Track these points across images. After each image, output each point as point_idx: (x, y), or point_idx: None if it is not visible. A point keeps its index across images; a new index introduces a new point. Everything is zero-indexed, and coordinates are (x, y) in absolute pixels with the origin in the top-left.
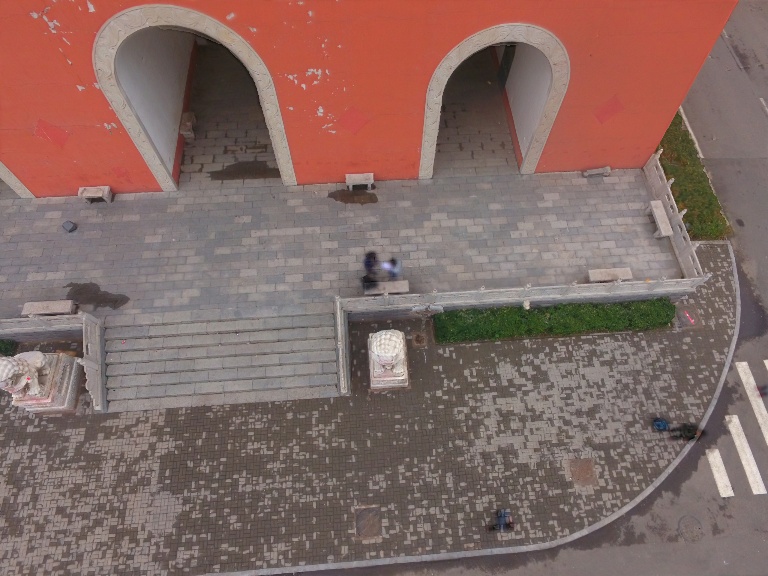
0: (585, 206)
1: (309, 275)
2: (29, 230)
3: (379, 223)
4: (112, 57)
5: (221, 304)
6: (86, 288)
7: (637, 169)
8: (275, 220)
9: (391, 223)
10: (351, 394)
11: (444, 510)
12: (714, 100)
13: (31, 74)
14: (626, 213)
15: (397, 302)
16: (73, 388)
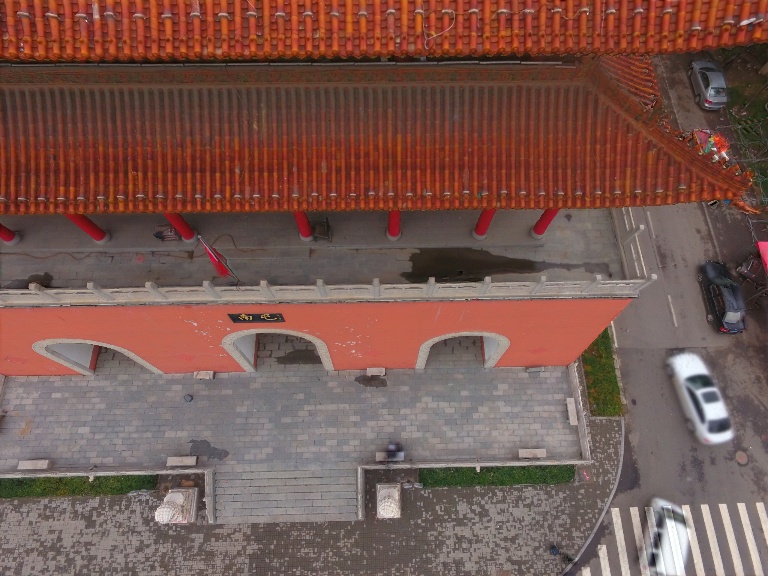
0: (524, 395)
1: (341, 441)
2: (163, 399)
3: (387, 403)
4: (234, 340)
5: (286, 460)
6: (202, 444)
7: (564, 367)
8: (320, 398)
9: (395, 403)
10: (365, 519)
11: None
12: None
13: (185, 343)
14: (551, 402)
15: None
16: (196, 508)
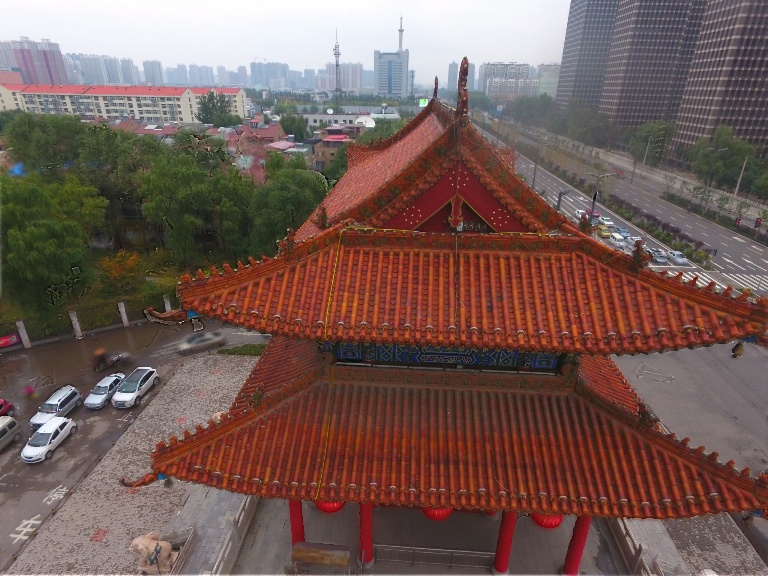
0: None
1: None
2: None
3: None
4: None
5: None
6: None
7: None
8: None
9: None
10: None
11: None
12: None
13: None
14: None
15: None
16: None
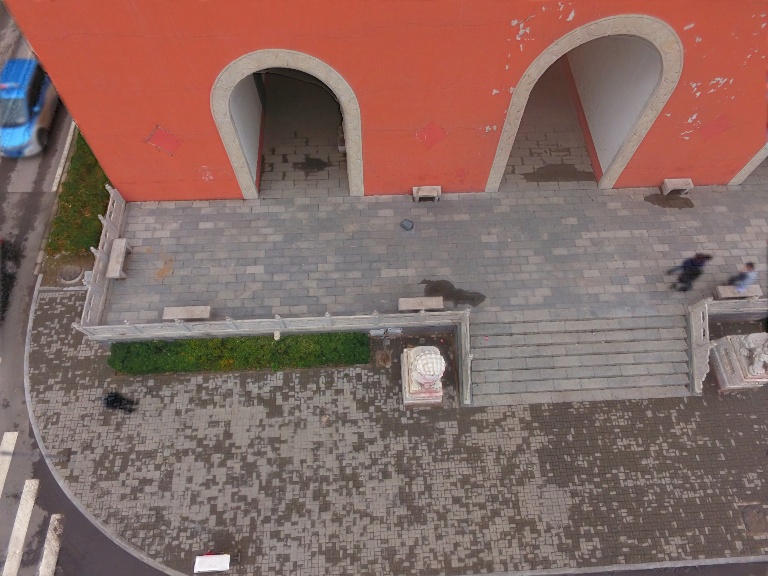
0: None
1: (651, 277)
2: (368, 227)
3: (702, 228)
4: (549, 63)
5: (575, 304)
6: (440, 285)
7: None
8: (601, 222)
9: (714, 228)
10: (702, 394)
11: None
12: None
13: (461, 78)
14: None
15: (750, 305)
16: None
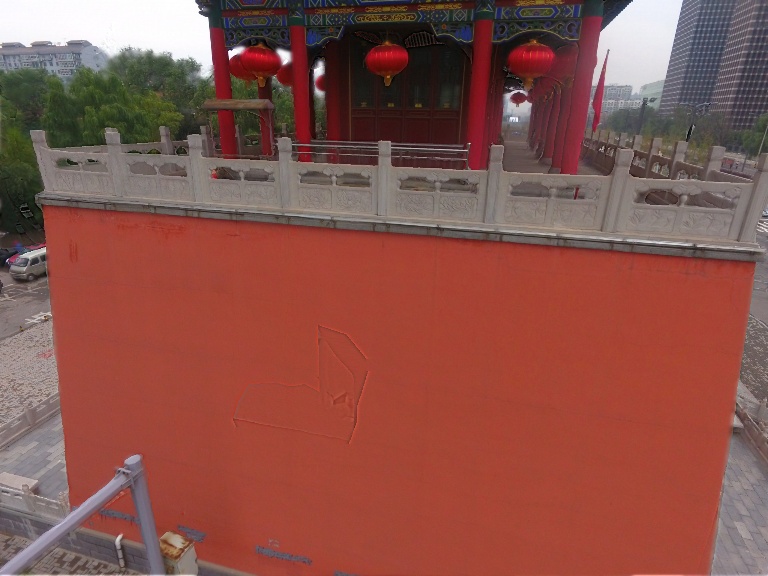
0: None
1: None
2: None
3: None
4: None
5: None
6: None
7: None
8: None
9: None
10: None
11: (760, 336)
12: None
13: None
14: None
15: None
16: None
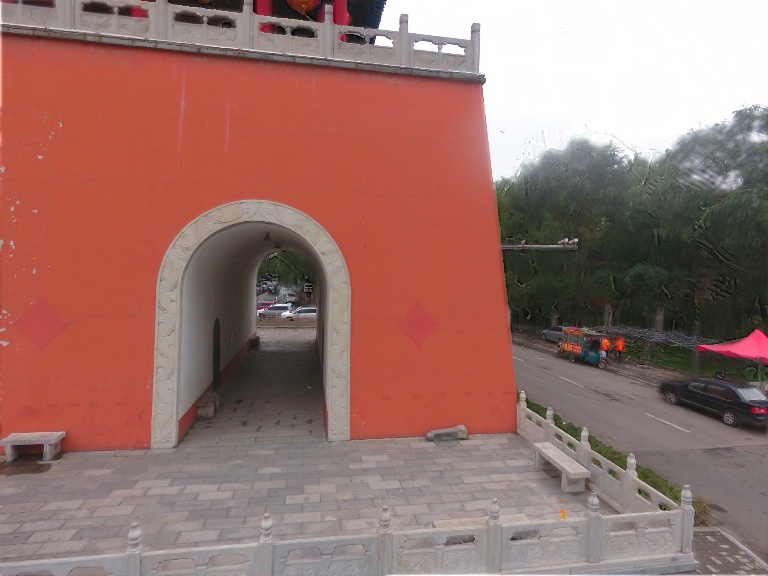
0: (432, 465)
1: None
2: None
3: (14, 495)
4: None
5: None
6: None
7: (509, 434)
8: None
9: (41, 494)
10: None
11: None
12: (594, 415)
13: None
14: (504, 469)
15: None
16: None
